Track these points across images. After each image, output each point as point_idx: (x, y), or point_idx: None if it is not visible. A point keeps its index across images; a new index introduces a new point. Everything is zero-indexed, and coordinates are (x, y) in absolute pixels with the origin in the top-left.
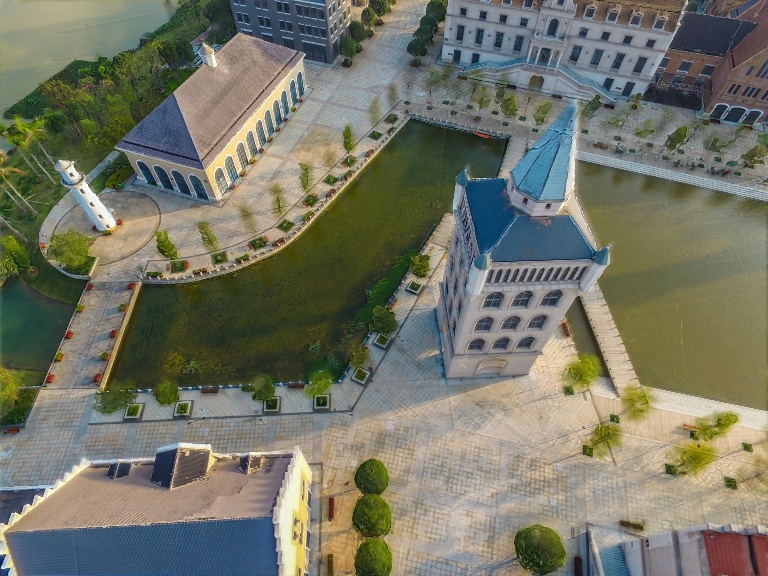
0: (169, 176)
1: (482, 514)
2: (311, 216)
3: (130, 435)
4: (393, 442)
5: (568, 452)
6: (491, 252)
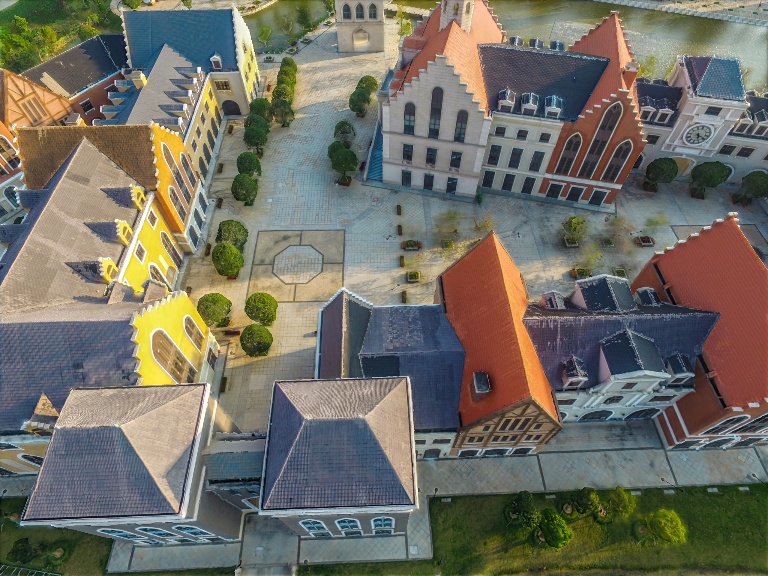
0: None
1: (346, 90)
2: None
3: None
4: (305, 71)
5: None
6: None
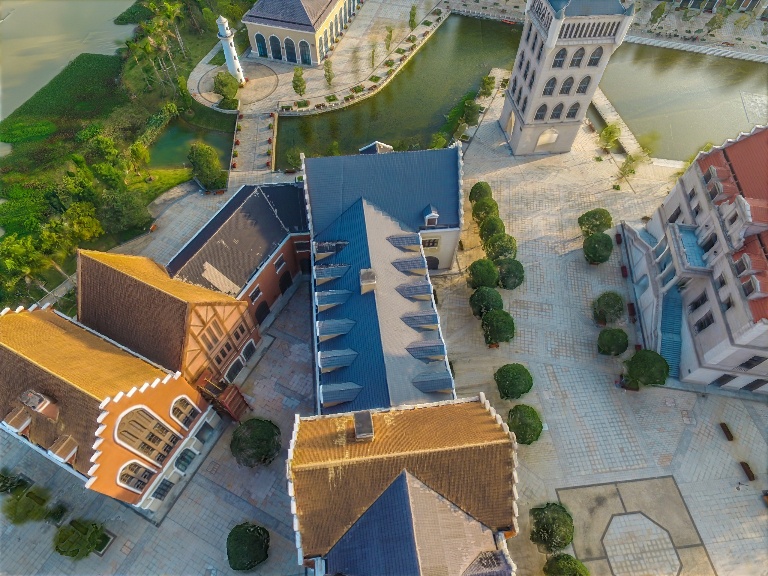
0: (281, 45)
1: (553, 219)
2: (393, 72)
3: None
4: None
5: (603, 188)
6: (564, 10)
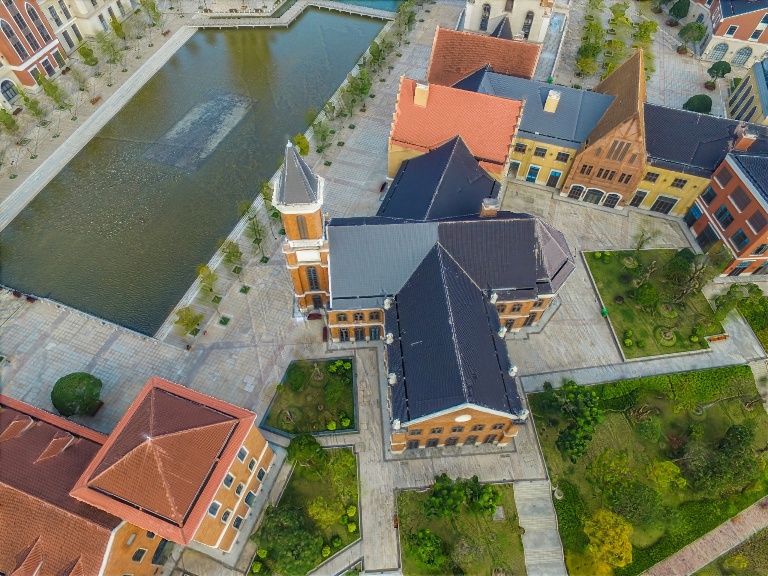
0: None
1: None
2: None
3: None
4: None
5: (173, 4)
6: None
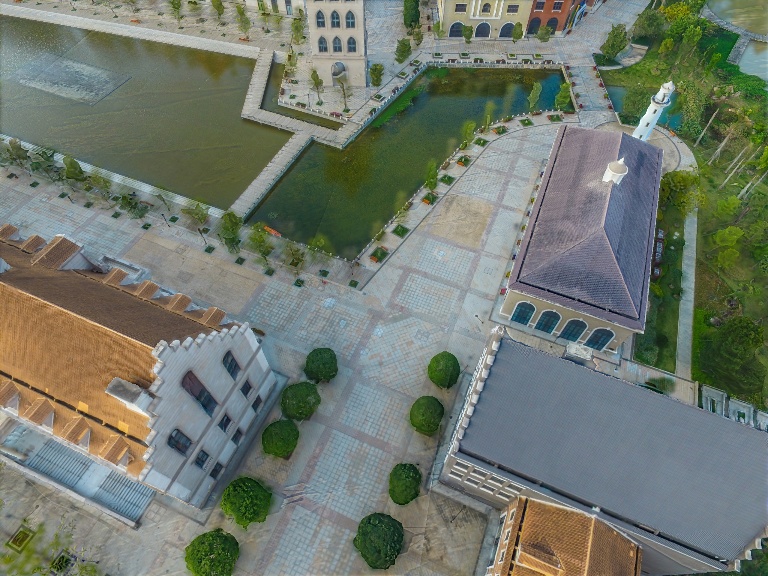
0: None
1: None
2: None
3: (535, 51)
4: None
5: None
6: None
